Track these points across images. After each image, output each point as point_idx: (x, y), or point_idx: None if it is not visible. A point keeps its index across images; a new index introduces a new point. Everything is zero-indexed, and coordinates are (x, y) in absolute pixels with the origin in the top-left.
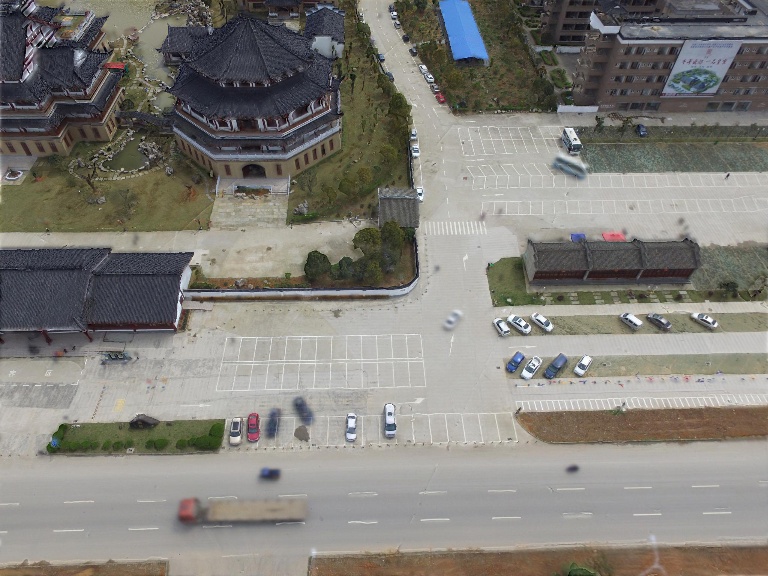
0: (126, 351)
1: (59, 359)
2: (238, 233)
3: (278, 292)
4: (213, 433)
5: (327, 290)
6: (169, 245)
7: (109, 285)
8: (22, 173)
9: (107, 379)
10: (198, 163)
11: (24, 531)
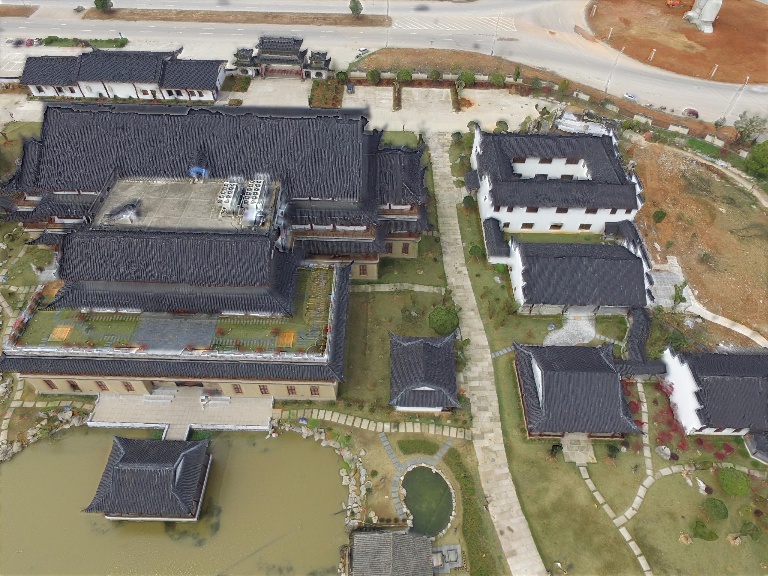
0: None
1: None
2: None
3: None
4: (49, 38)
5: None
6: None
7: None
8: None
9: None
10: None
11: None
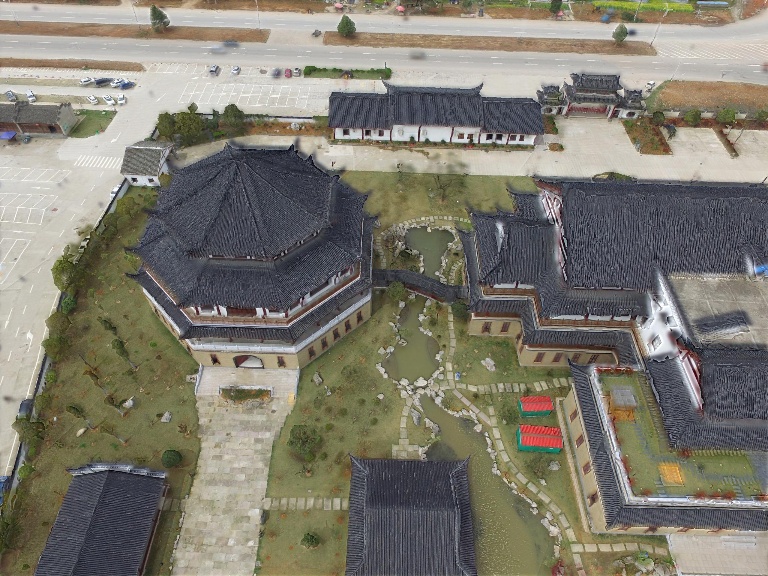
0: None
1: None
2: None
3: None
4: (308, 68)
5: None
6: (358, 160)
7: None
8: None
9: None
10: None
11: None
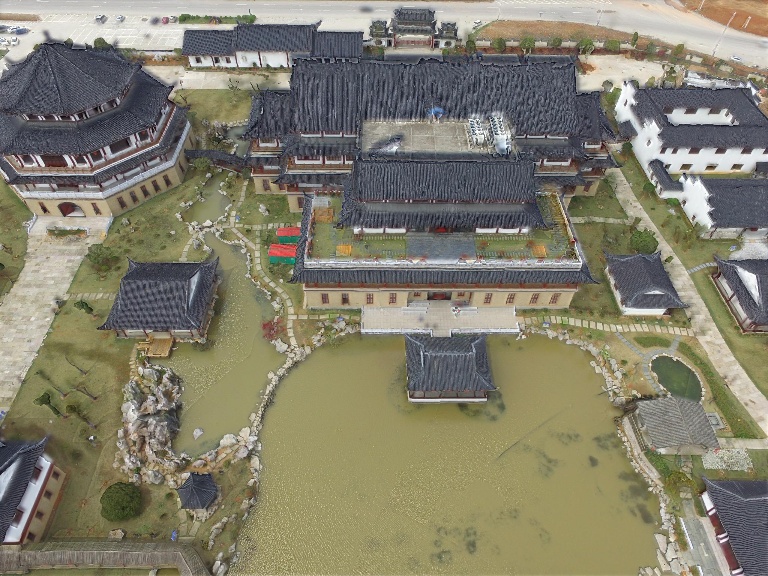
0: None
1: None
2: None
3: None
4: (183, 16)
5: None
6: (207, 81)
7: None
8: None
9: None
10: None
11: (258, 4)
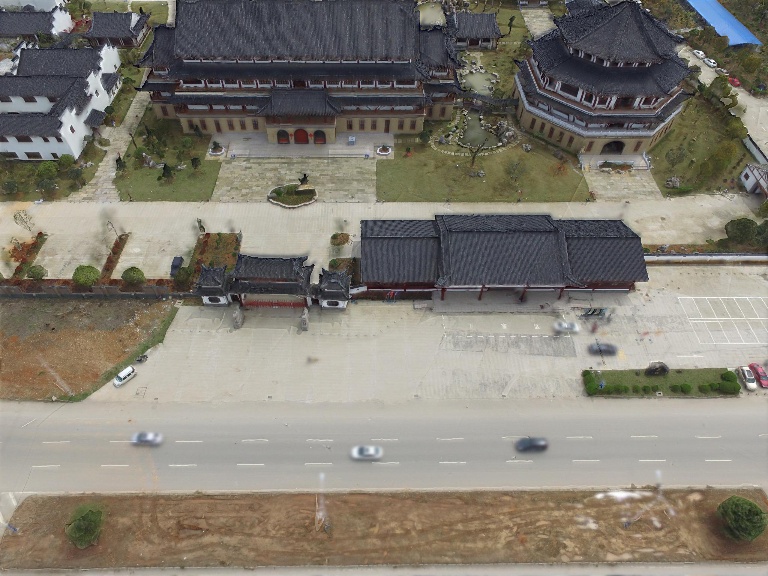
0: (594, 308)
1: (538, 314)
2: (625, 204)
3: (707, 257)
4: (732, 379)
5: (753, 255)
6: (568, 215)
7: (578, 247)
8: (390, 149)
9: (594, 332)
10: (548, 140)
11: (614, 460)
